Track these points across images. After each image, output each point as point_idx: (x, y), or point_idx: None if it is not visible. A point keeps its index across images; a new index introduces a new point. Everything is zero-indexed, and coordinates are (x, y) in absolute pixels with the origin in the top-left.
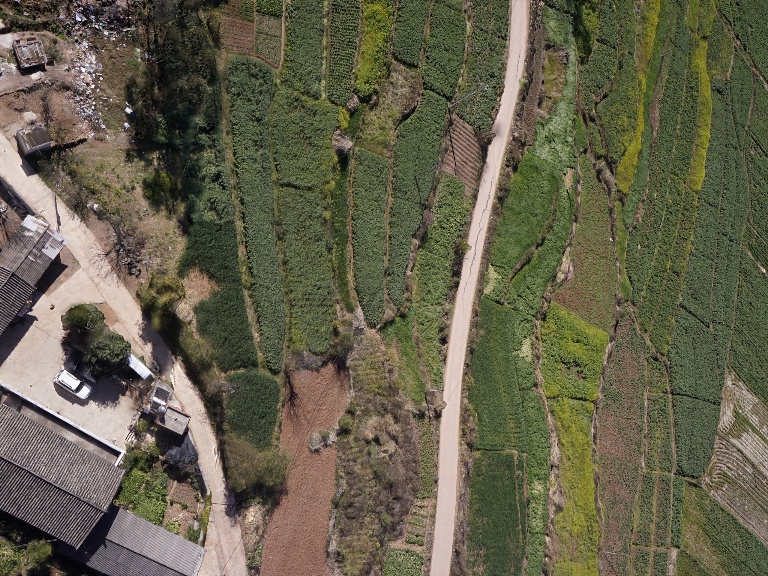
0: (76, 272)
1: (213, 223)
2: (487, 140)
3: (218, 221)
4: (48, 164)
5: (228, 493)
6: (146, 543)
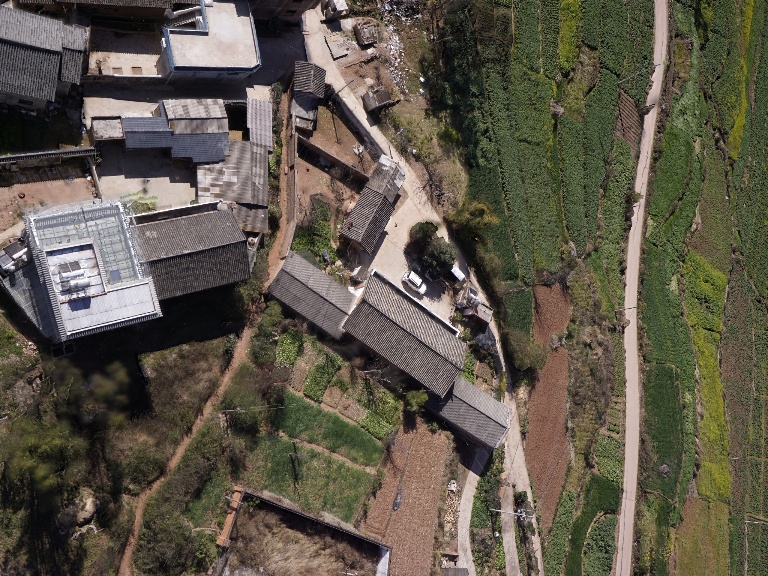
0: (406, 200)
1: (486, 167)
2: (646, 110)
3: (489, 166)
4: (384, 118)
5: (507, 374)
6: (476, 400)
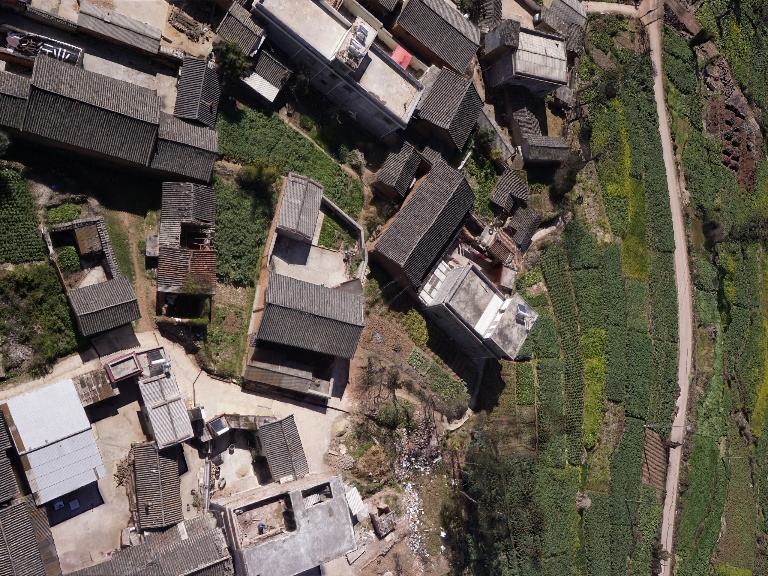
0: None
1: None
2: (672, 446)
3: None
4: None
5: None
6: None
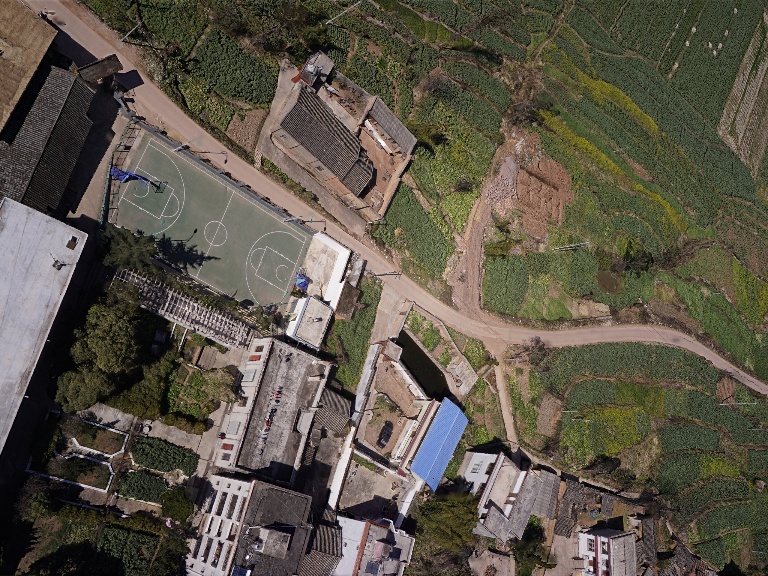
0: None
1: None
2: None
3: None
4: None
5: None
6: None
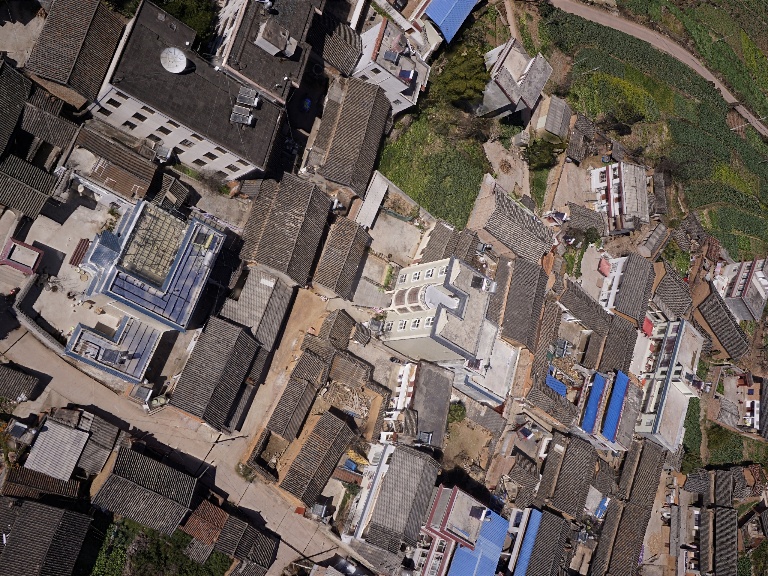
0: None
1: None
2: None
3: None
4: None
5: None
6: None
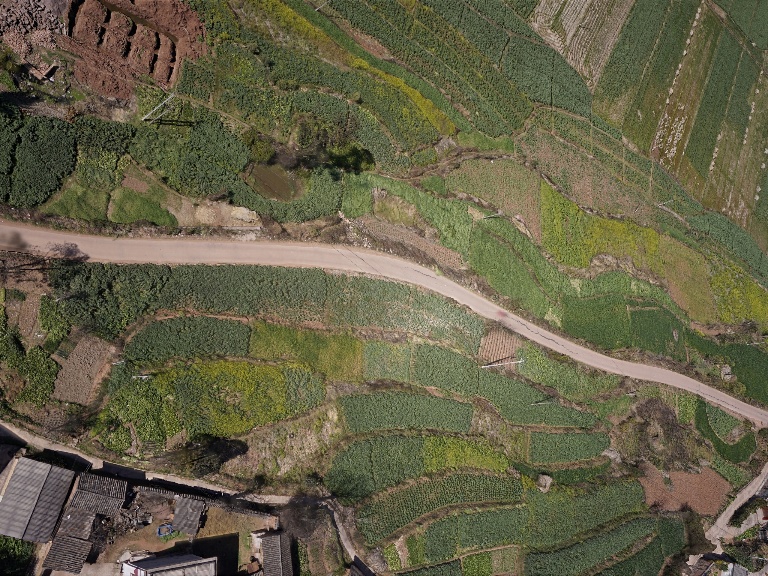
0: None
1: None
2: None
3: None
4: None
5: None
6: None
